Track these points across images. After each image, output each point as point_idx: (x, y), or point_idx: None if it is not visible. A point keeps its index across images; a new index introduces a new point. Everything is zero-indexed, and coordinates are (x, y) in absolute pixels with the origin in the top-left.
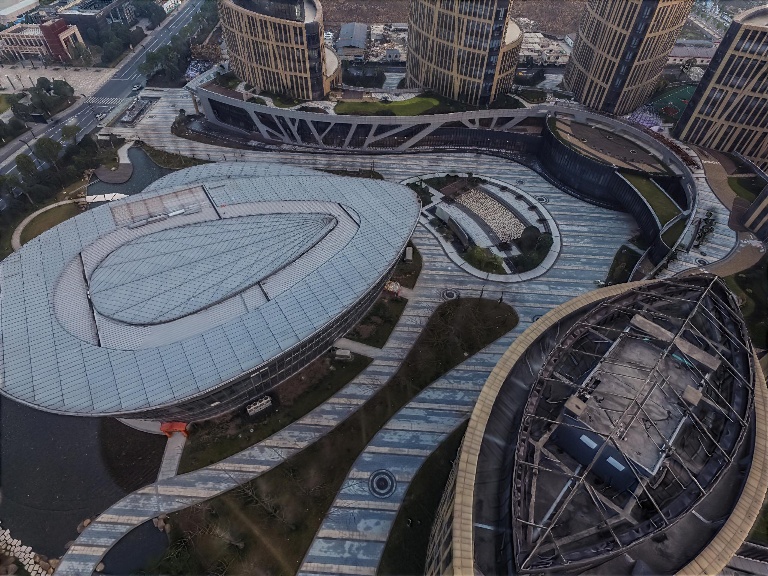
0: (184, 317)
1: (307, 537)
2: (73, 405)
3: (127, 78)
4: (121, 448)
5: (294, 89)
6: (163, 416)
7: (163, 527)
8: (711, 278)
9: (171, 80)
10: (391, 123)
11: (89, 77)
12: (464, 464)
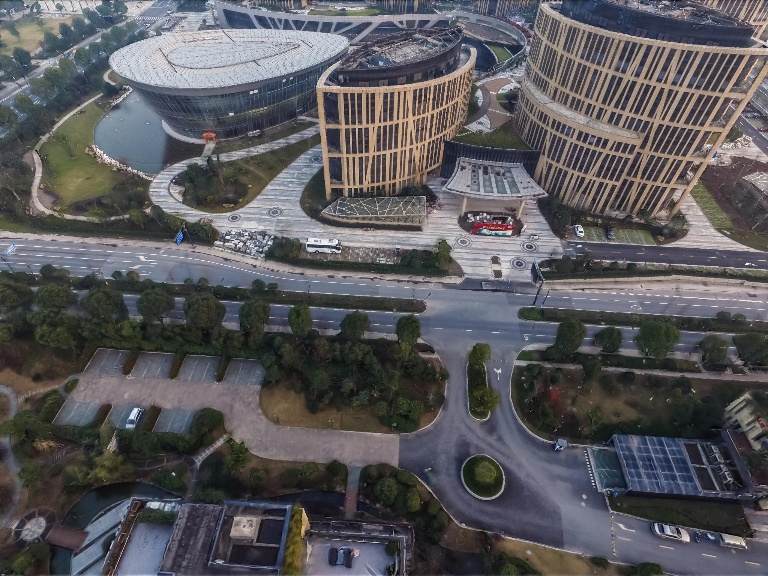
0: (216, 68)
1: (277, 172)
2: (168, 85)
3: (162, 6)
4: (181, 148)
5: (281, 1)
6: (206, 114)
7: (206, 168)
8: (458, 27)
9: (195, 7)
10: (345, 21)
11: (135, 6)
12: None
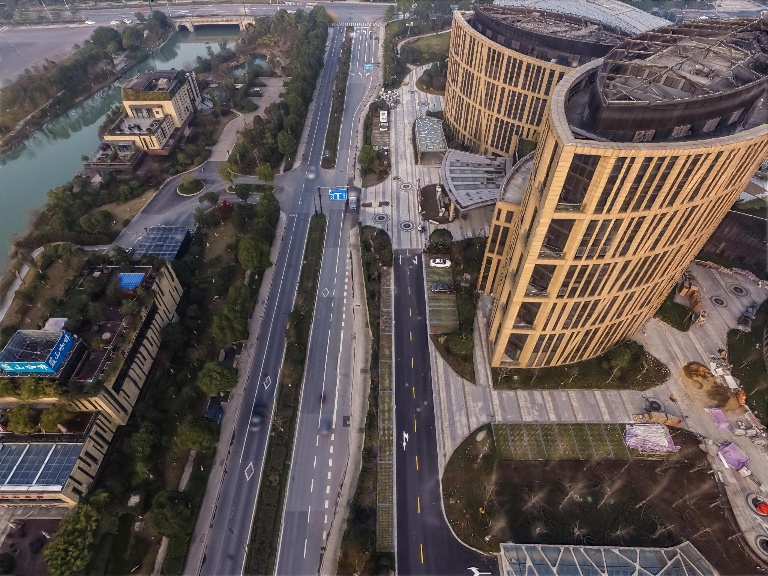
0: None
1: None
2: None
3: None
4: None
5: None
6: None
7: None
8: None
9: None
10: None
11: (746, 6)
12: None
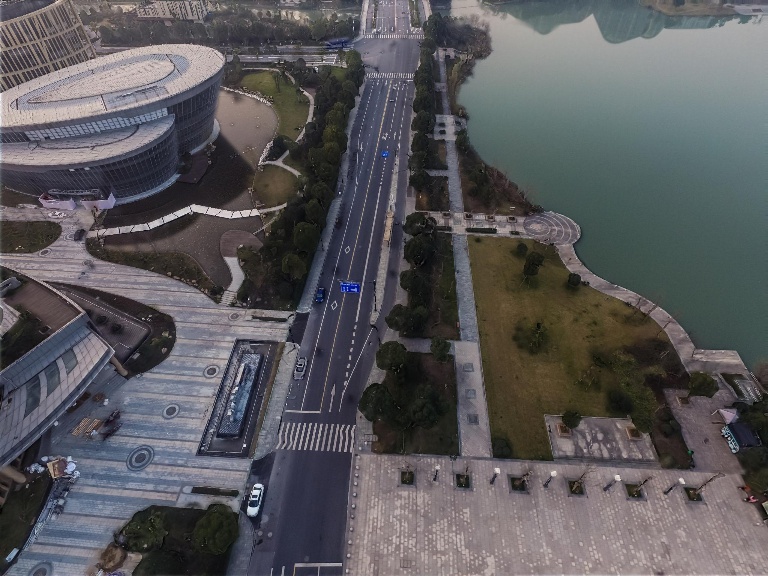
0: None
1: None
2: None
3: (297, 575)
4: None
5: None
6: None
7: None
8: None
9: None
10: None
11: None
12: None
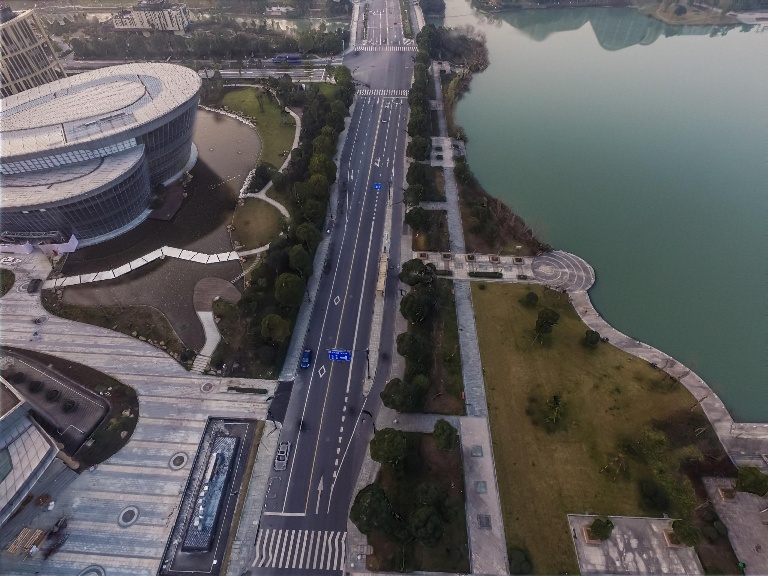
0: None
1: None
2: None
3: None
4: None
5: None
6: None
7: None
8: None
9: None
10: None
11: None
12: (6, 24)
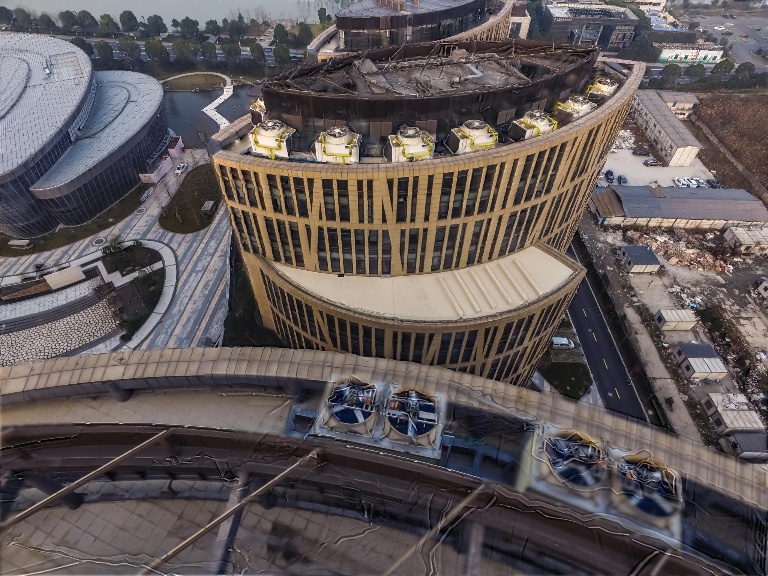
0: None
1: None
2: None
3: None
4: None
5: None
6: None
7: None
8: None
9: None
10: None
11: None
12: None
